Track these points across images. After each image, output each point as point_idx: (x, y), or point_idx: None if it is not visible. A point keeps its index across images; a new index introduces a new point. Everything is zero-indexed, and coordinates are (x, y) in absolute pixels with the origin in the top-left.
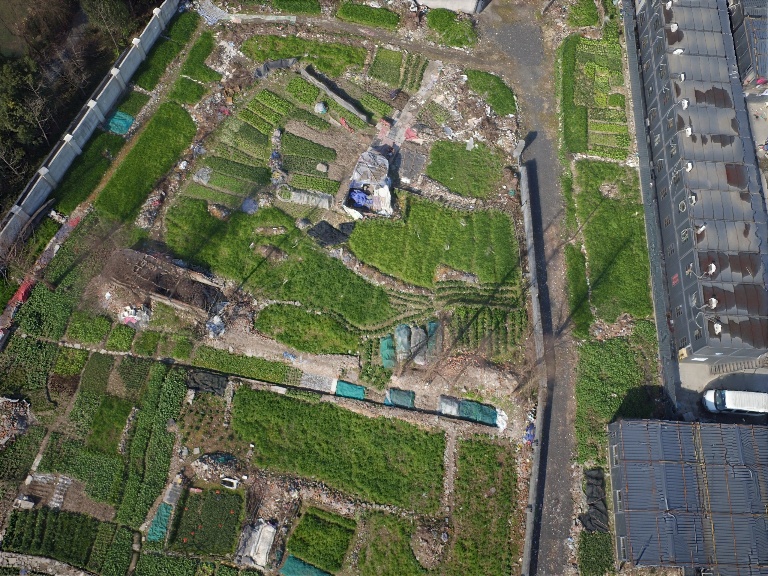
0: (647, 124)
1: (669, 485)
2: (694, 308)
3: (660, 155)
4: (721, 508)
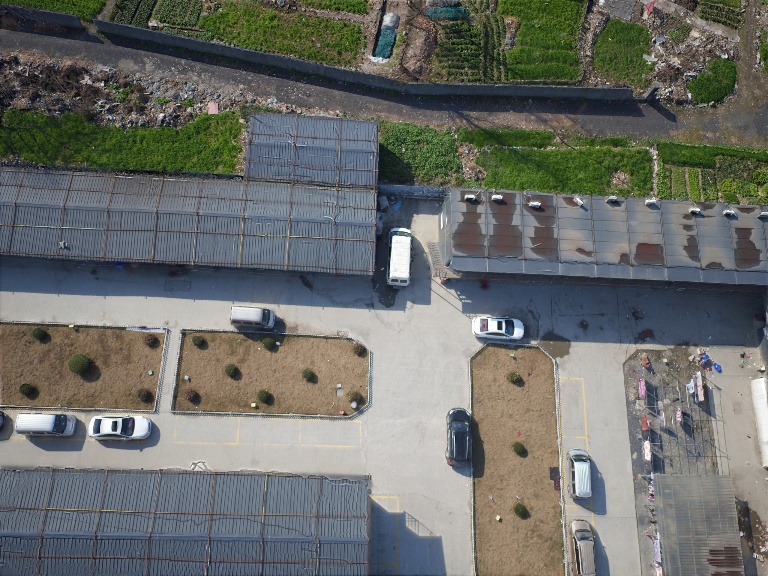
0: None
1: None
2: None
3: None
4: None
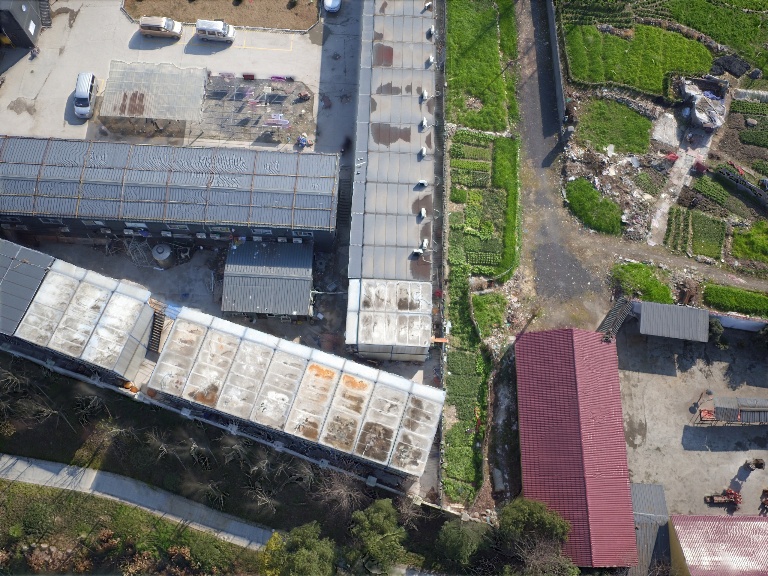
0: None
1: None
2: None
3: None
4: None
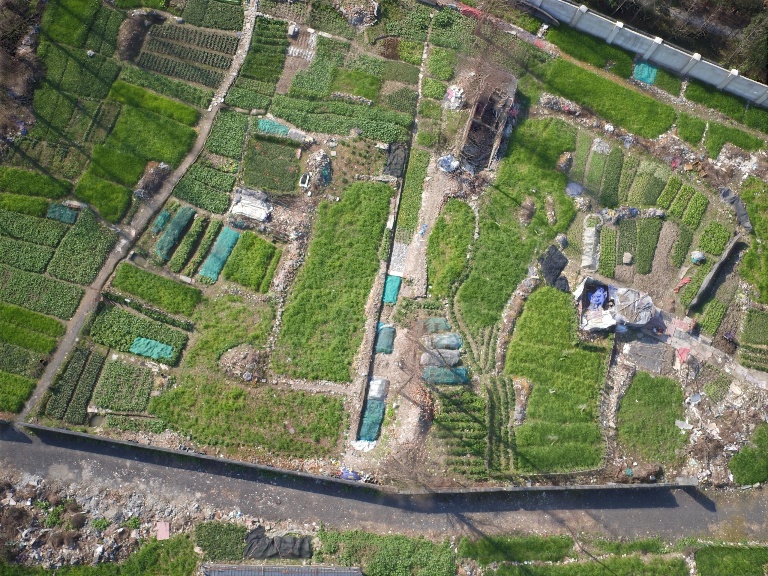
0: None
1: None
2: None
3: None
4: None
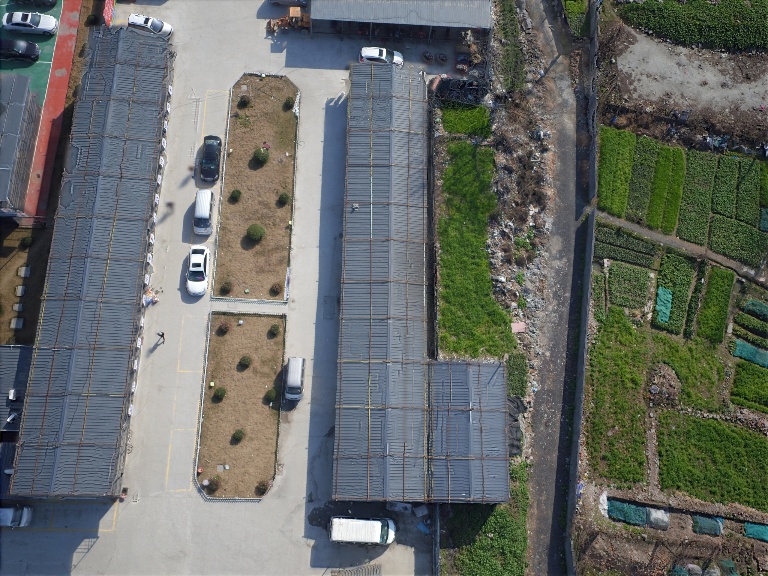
0: None
1: None
2: None
3: None
4: None
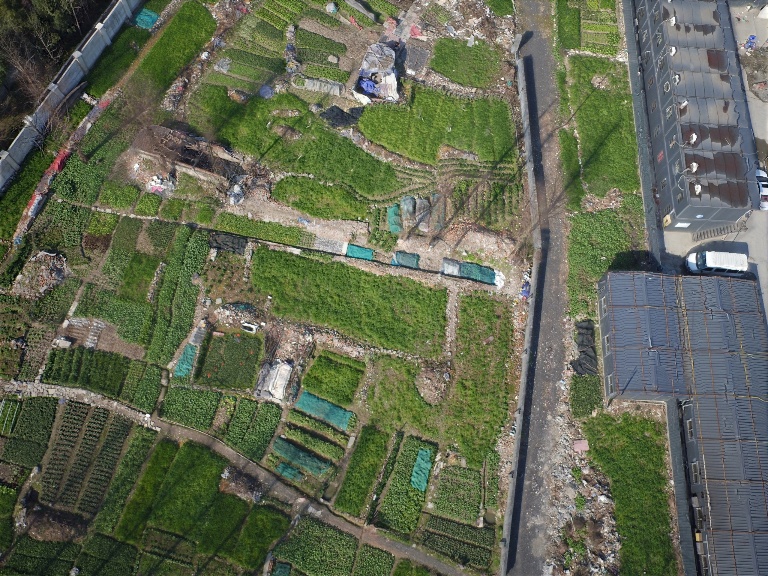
0: (636, 24)
1: (653, 326)
2: (677, 175)
3: (647, 48)
4: (700, 345)
